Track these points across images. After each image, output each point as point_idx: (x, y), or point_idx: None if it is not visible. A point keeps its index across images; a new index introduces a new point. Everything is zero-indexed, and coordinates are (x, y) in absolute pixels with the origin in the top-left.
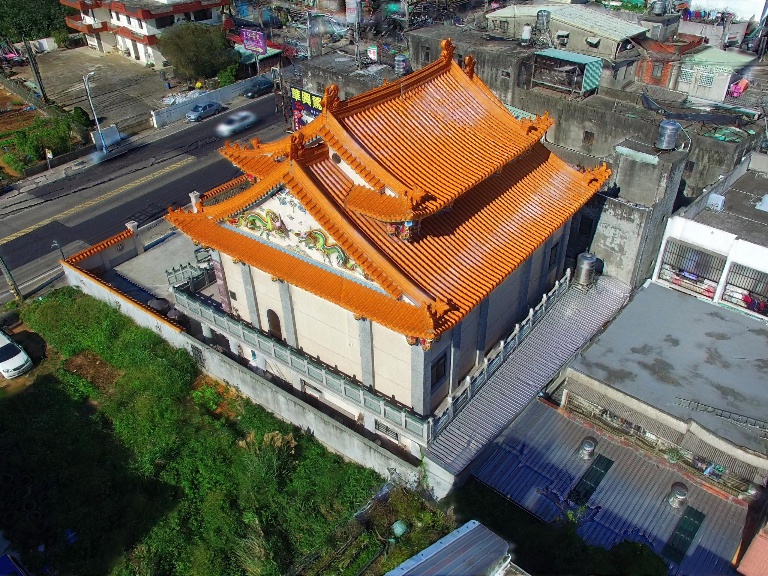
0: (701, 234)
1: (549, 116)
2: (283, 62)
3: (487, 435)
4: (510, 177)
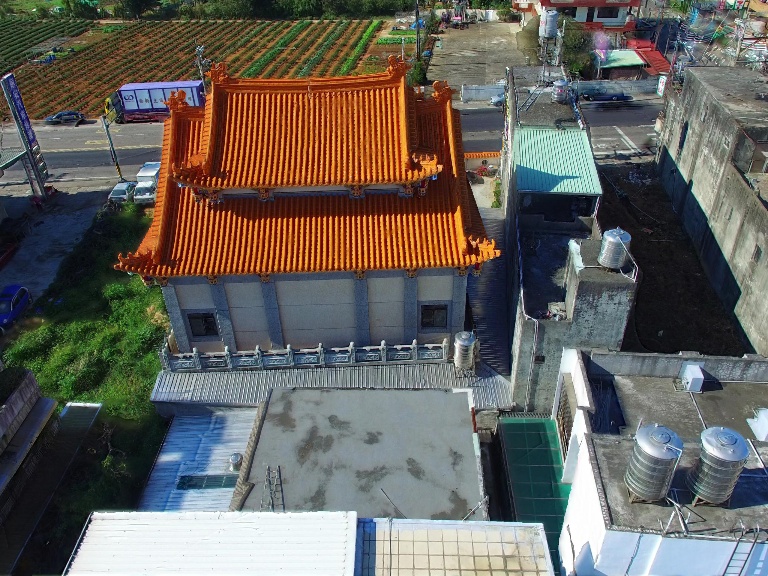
0: (579, 385)
1: (739, 210)
2: (642, 75)
3: (204, 397)
4: (382, 207)
